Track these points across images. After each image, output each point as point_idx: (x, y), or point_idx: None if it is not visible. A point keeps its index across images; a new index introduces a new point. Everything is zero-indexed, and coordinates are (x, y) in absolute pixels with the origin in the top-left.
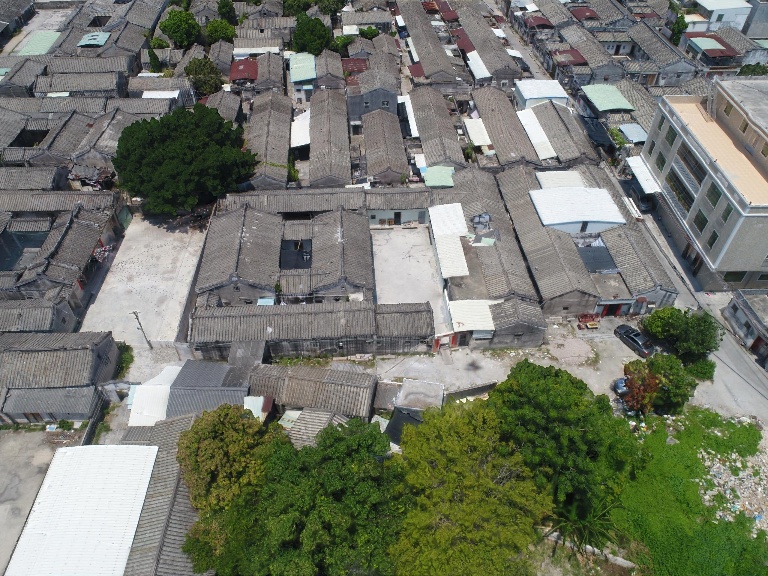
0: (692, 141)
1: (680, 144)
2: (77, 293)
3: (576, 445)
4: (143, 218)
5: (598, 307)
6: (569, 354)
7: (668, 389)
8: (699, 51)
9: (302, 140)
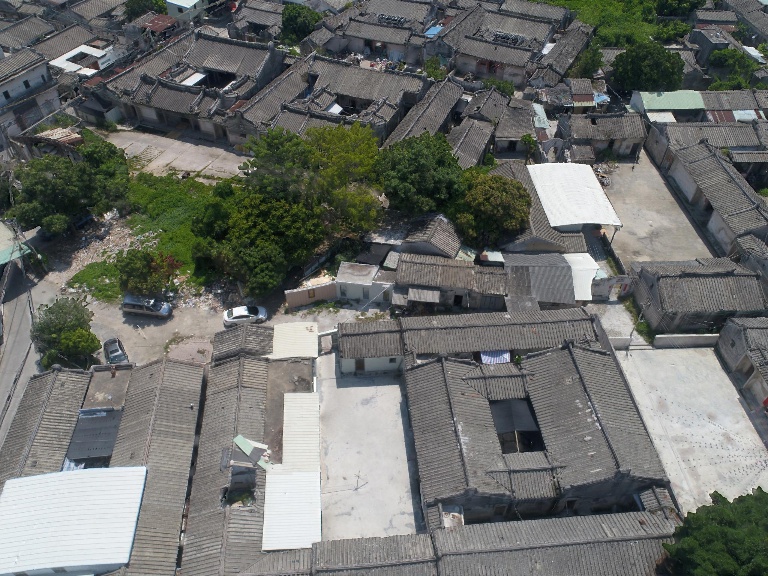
0: None
1: None
2: (761, 391)
3: None
4: None
5: None
6: (197, 344)
7: None
8: None
9: None
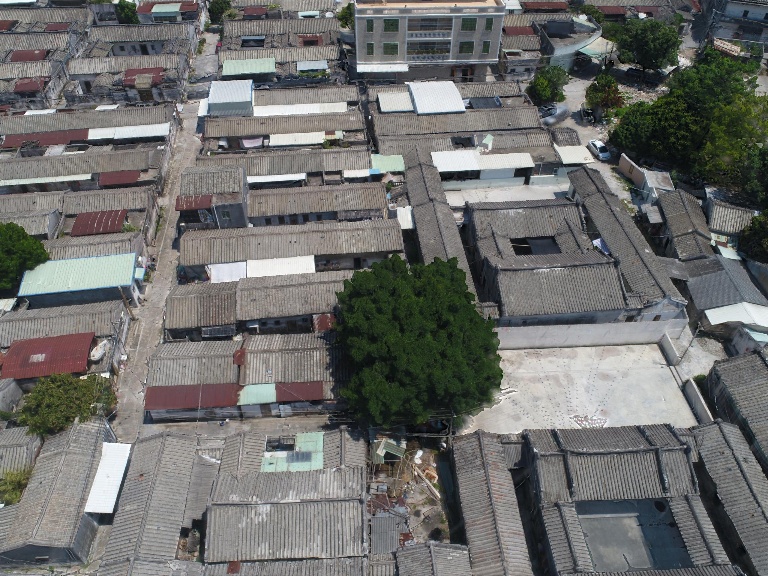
0: (420, 12)
1: (408, 22)
2: None
3: None
4: None
5: None
6: None
7: None
8: (175, 14)
9: (302, 265)
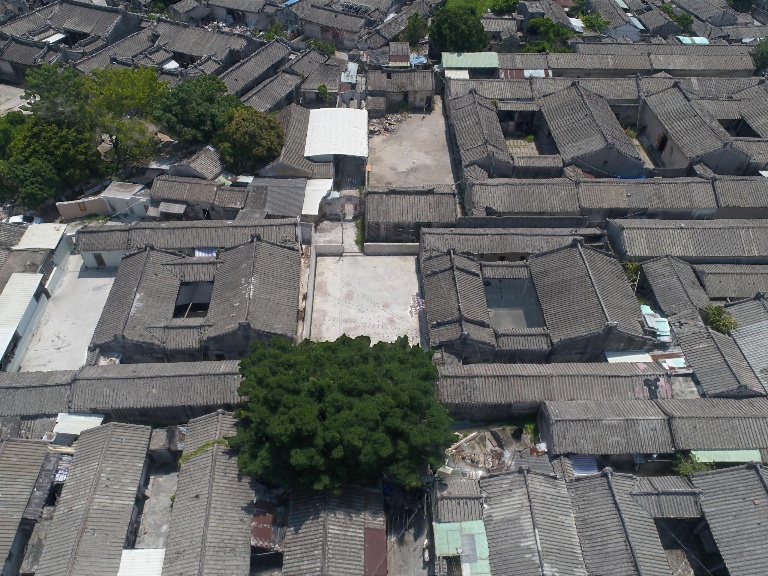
0: None
1: None
2: None
3: None
4: None
5: None
6: None
7: None
8: None
9: (137, 568)
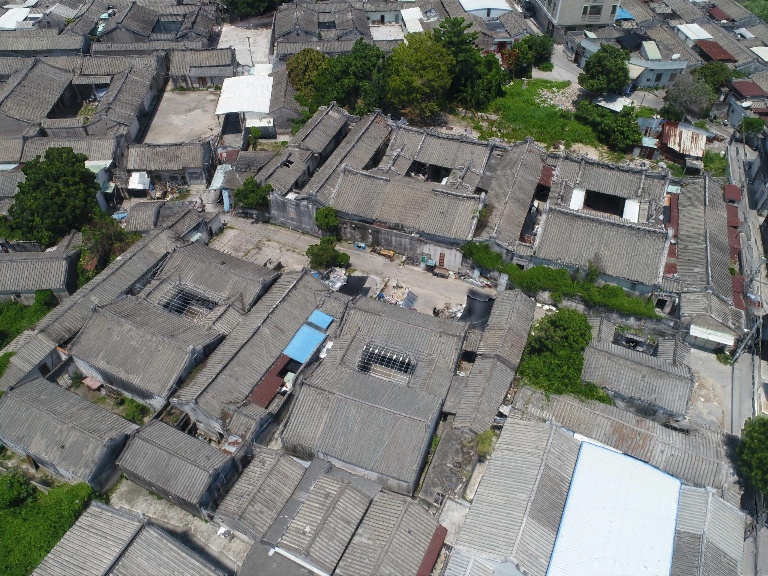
0: None
1: None
2: None
3: (465, 38)
4: (230, 25)
5: (494, 46)
6: None
7: (520, 56)
8: None
9: None
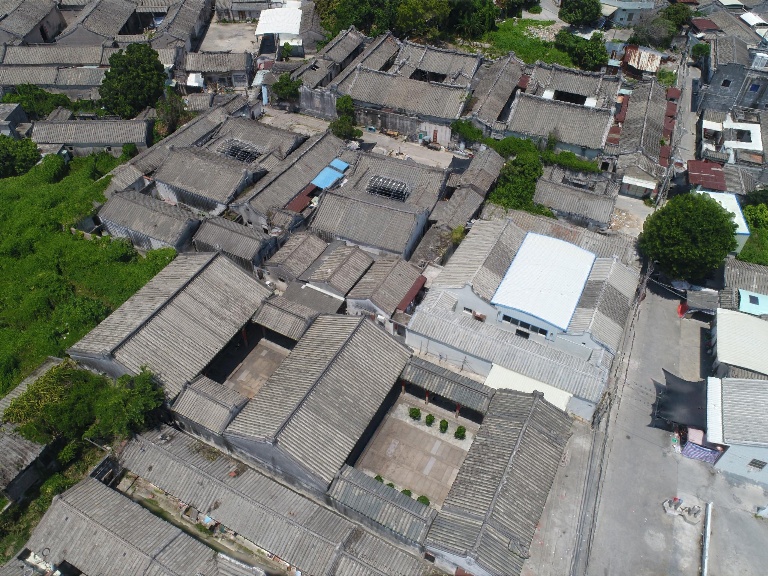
0: None
1: None
2: None
3: None
4: None
5: None
6: None
7: None
8: None
9: None
